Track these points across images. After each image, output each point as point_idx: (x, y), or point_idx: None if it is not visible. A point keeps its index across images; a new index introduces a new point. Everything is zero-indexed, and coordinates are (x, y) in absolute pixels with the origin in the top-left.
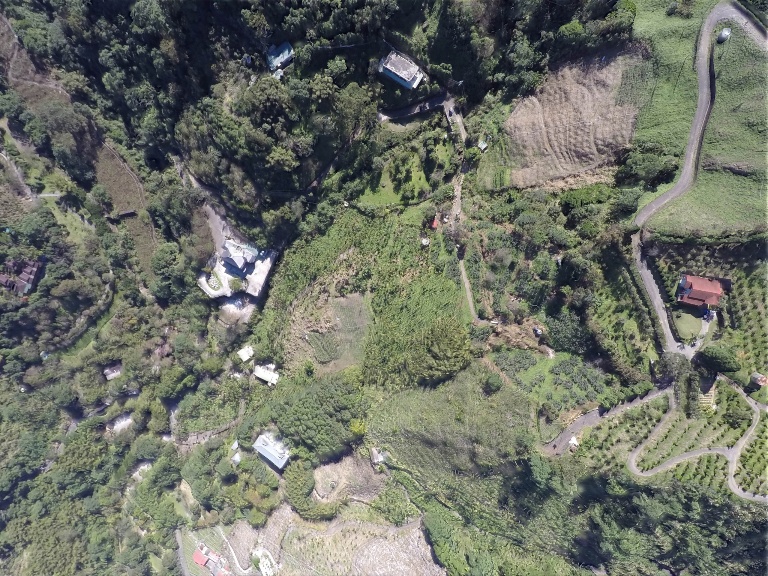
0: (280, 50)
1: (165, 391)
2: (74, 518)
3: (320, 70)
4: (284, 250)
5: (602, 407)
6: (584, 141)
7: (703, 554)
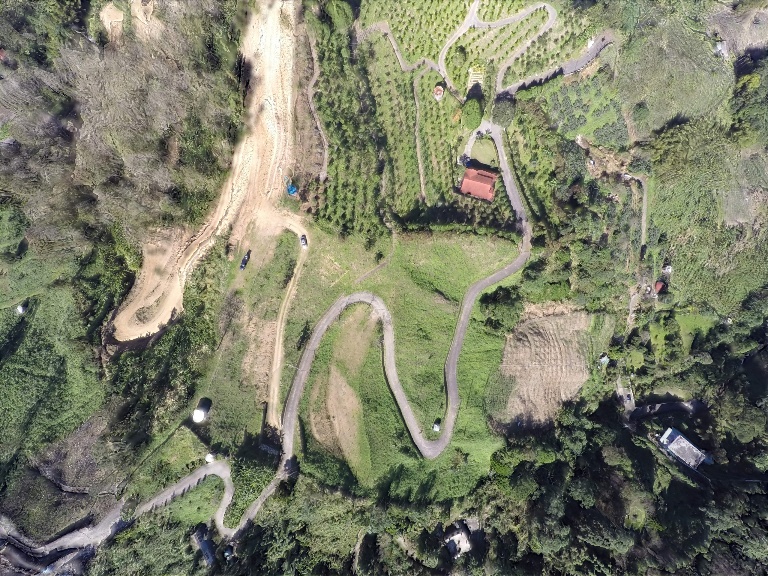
0: None
1: None
2: None
3: None
4: None
5: None
6: (539, 347)
7: None
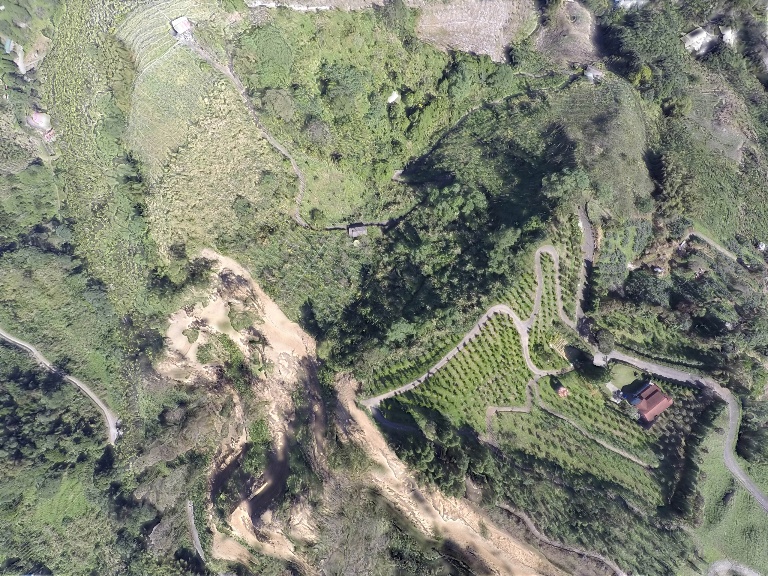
0: None
1: None
2: None
3: None
4: None
5: (592, 267)
6: None
7: None
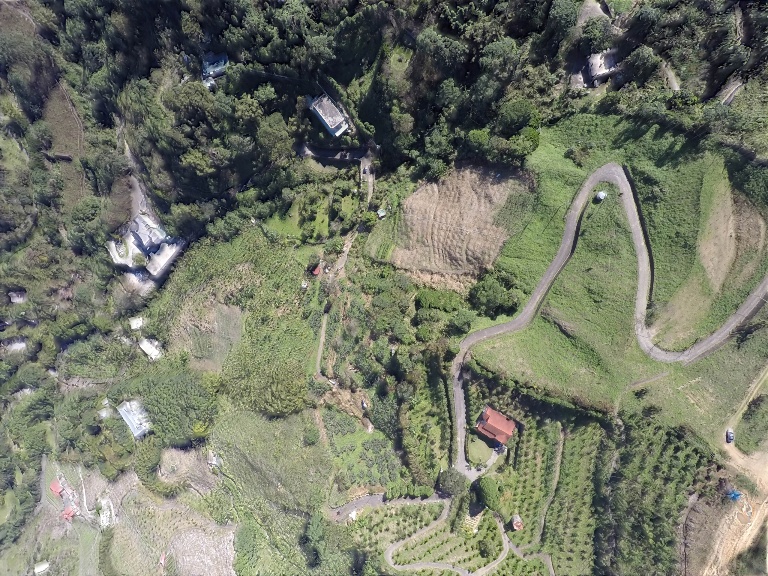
0: (216, 59)
1: (56, 331)
2: None
3: (251, 90)
4: (191, 241)
5: None
6: (457, 247)
7: None
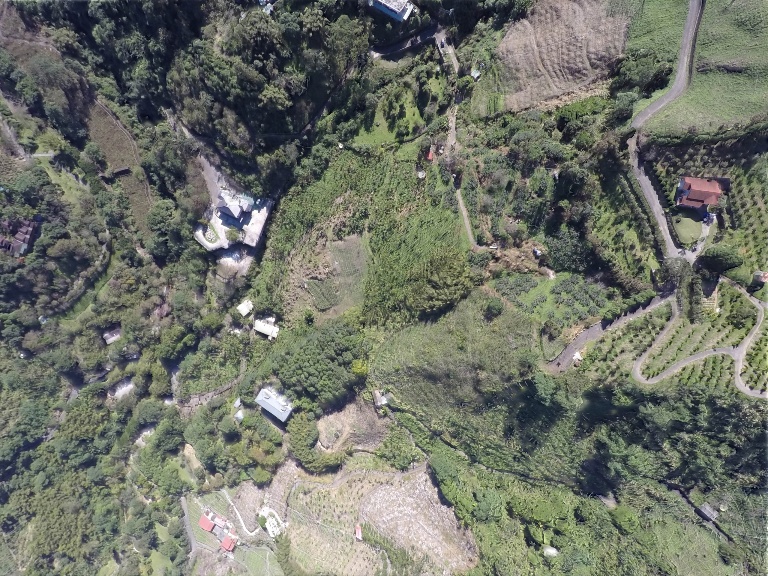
0: None
1: (165, 351)
2: (78, 489)
3: (310, 4)
4: (280, 198)
5: (605, 320)
6: (577, 56)
7: (712, 463)
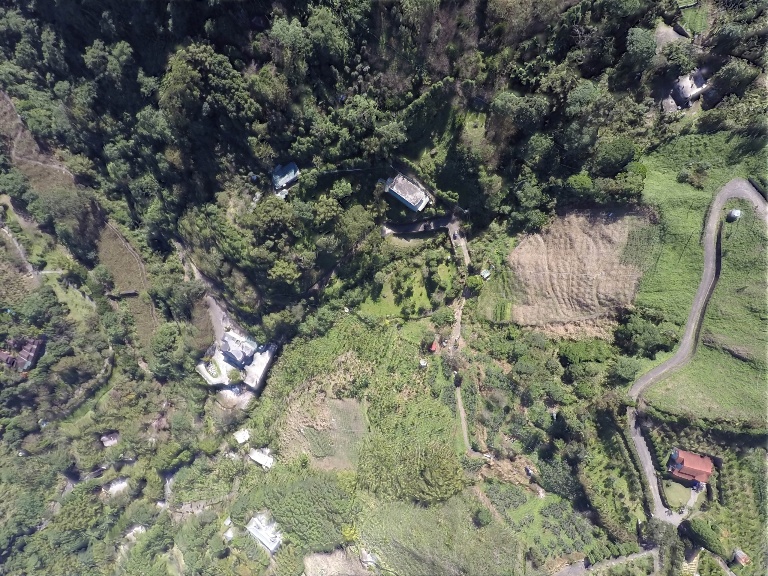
0: (286, 170)
1: (161, 465)
2: (68, 569)
3: (325, 190)
4: (283, 344)
5: (588, 559)
6: (586, 293)
7: None
